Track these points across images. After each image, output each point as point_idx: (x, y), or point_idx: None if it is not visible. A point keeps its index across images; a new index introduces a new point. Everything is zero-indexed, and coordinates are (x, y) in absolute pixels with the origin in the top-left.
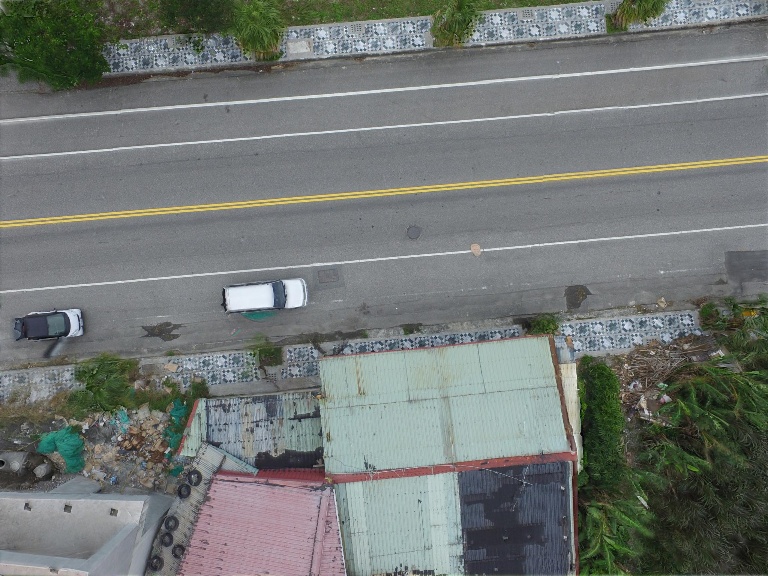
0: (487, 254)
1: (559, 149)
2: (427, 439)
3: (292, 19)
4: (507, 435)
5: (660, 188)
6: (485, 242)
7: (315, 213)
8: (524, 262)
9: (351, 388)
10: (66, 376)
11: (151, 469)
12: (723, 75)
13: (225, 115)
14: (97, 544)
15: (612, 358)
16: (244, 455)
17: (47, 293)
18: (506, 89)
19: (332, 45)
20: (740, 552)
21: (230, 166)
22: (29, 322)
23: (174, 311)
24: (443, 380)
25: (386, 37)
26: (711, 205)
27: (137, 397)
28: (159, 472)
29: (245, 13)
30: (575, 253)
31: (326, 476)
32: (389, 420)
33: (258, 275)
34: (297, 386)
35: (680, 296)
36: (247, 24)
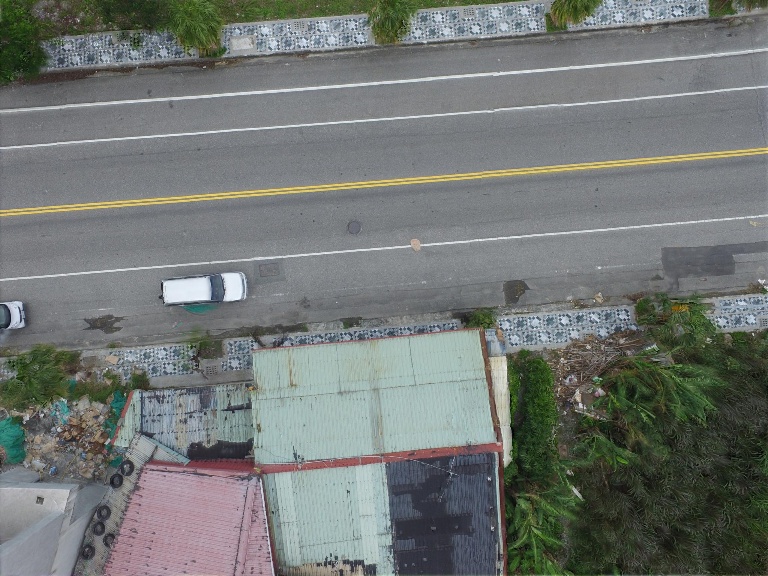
0: (427, 249)
1: (499, 146)
2: (356, 430)
3: (236, 16)
4: (435, 426)
5: (598, 185)
6: (425, 237)
7: (257, 208)
8: (463, 257)
9: (283, 380)
10: (8, 368)
11: (91, 460)
12: (661, 74)
13: (168, 110)
14: None
15: (549, 352)
16: (177, 446)
17: None
18: (447, 86)
19: (275, 42)
20: (668, 543)
21: (173, 161)
22: None
23: (116, 304)
24: (374, 372)
25: (329, 34)
26: (648, 202)
27: (77, 389)
28: (99, 463)
29: (181, 9)
30: (513, 248)
31: (255, 466)
32: (319, 411)
33: (200, 269)
34: (237, 379)
35: (617, 291)
36: (183, 20)
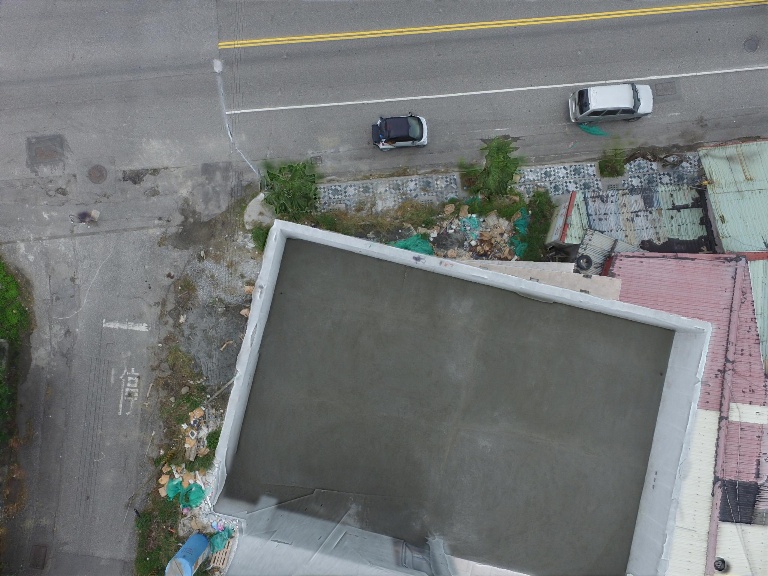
0: None
1: None
2: None
3: None
4: None
5: None
6: None
7: (652, 26)
8: None
9: (737, 175)
10: (410, 186)
11: None
12: None
13: None
14: None
15: None
16: None
17: (388, 105)
18: None
19: None
20: None
21: None
22: (394, 121)
23: (512, 124)
24: None
25: None
26: None
27: (486, 204)
28: None
29: None
30: None
31: None
32: None
33: None
34: None
35: None
36: None
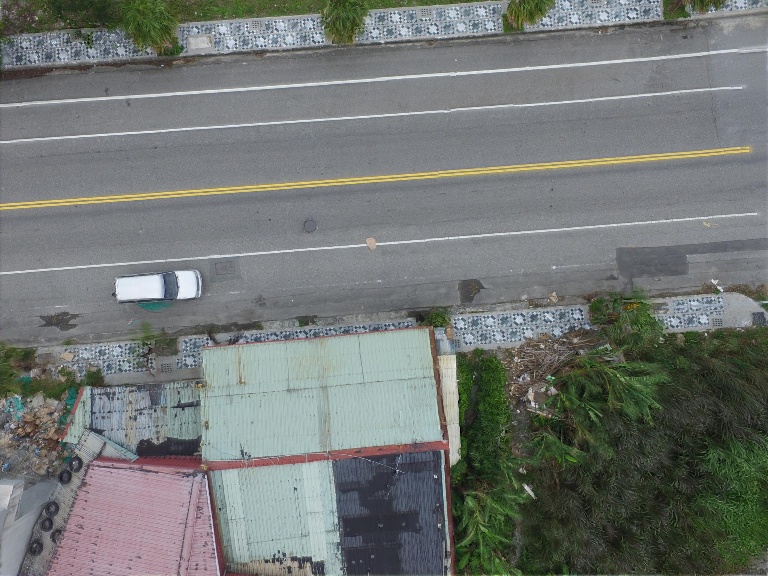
0: (382, 248)
1: (455, 145)
2: (304, 428)
3: (195, 15)
4: (382, 424)
5: (553, 185)
6: (381, 236)
7: (213, 206)
8: (419, 256)
9: (232, 377)
10: None
11: (44, 457)
12: (617, 75)
13: (126, 109)
14: None
15: (503, 351)
16: (126, 442)
17: None
18: (404, 86)
19: (233, 41)
20: (616, 541)
21: (129, 159)
22: None
23: (72, 301)
24: (323, 370)
25: (286, 34)
26: (603, 202)
27: (31, 385)
28: (53, 460)
29: (133, 8)
30: (469, 248)
31: (202, 463)
32: (268, 409)
33: (156, 266)
34: (192, 376)
35: (572, 291)
36: (135, 19)
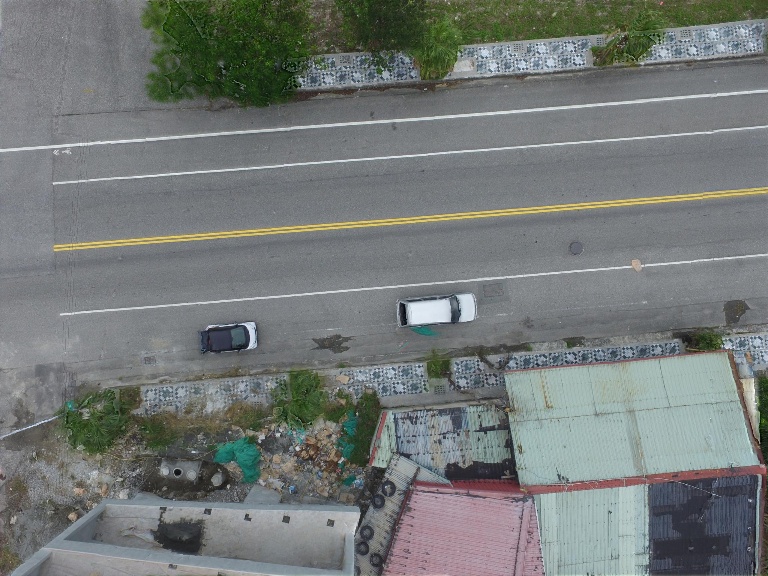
0: (648, 269)
1: (717, 167)
2: (616, 452)
3: (455, 38)
4: (695, 448)
5: None
6: (646, 258)
7: (480, 229)
8: (684, 277)
9: (538, 402)
10: (241, 387)
11: (326, 478)
12: None
13: (392, 132)
14: (315, 554)
15: None
16: (434, 466)
17: (221, 306)
18: (665, 108)
19: (495, 64)
20: None
21: (397, 182)
22: (215, 335)
23: (344, 324)
24: (628, 394)
25: (548, 56)
26: None
27: None
28: (332, 481)
29: (433, 35)
30: (734, 269)
31: (521, 488)
32: (578, 433)
33: (425, 289)
34: (464, 398)
35: None
36: (436, 46)
